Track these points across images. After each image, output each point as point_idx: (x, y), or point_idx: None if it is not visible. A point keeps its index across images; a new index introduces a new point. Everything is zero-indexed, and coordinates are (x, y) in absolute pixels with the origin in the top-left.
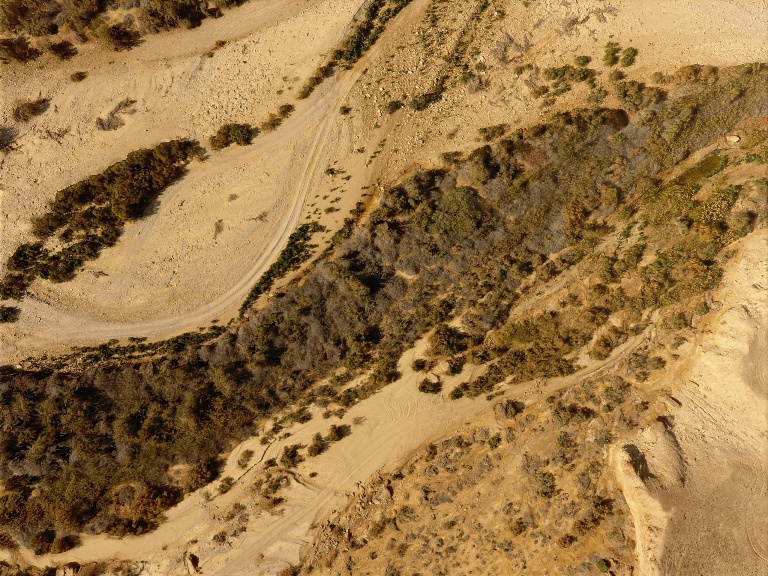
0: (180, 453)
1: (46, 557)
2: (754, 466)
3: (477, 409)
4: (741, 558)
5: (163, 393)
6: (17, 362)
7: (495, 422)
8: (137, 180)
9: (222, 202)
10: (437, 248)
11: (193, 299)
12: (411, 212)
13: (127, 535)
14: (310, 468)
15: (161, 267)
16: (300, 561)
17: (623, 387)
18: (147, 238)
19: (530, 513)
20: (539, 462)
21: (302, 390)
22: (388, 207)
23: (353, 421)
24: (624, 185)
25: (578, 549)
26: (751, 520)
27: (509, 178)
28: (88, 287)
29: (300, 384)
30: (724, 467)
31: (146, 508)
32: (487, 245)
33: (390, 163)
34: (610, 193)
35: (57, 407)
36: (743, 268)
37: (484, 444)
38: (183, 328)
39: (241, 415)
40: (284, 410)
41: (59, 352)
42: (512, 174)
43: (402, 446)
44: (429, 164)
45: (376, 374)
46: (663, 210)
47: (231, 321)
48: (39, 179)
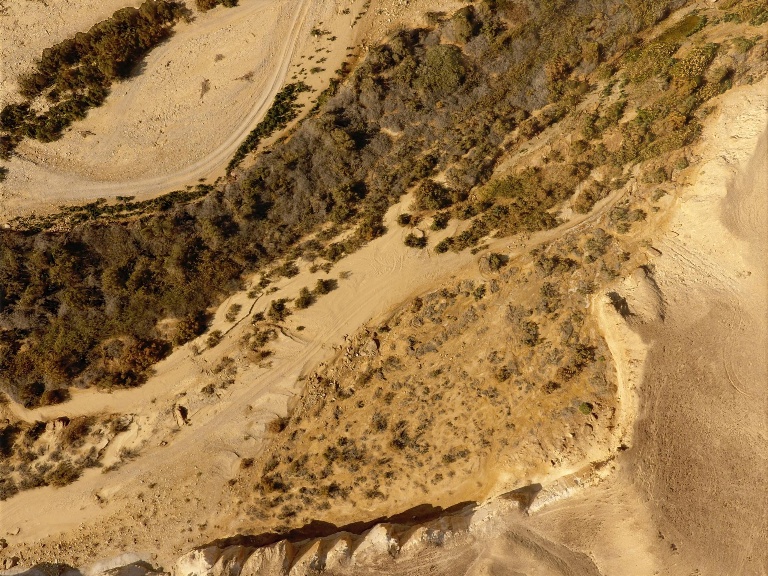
0: (168, 307)
1: (36, 412)
2: (732, 304)
3: (462, 263)
4: (719, 391)
5: (151, 248)
6: (5, 222)
7: (479, 275)
8: (123, 37)
9: (208, 62)
10: (421, 105)
11: (180, 158)
12: (395, 67)
13: (116, 389)
14: (297, 322)
15: (148, 126)
16: (288, 413)
17: (605, 238)
18: (134, 98)
19: (514, 361)
20: (523, 312)
21: (289, 245)
22: (373, 64)
23: (340, 275)
24: (605, 41)
25: (561, 395)
26: (729, 354)
27: (492, 34)
28: (75, 147)
29: (287, 237)
30: (703, 305)
31: (135, 358)
32: (471, 101)
33: (375, 24)
34: (591, 46)
35: (45, 262)
36: (722, 123)
37: (469, 296)
38: (170, 187)
39: (228, 267)
40: (271, 265)
41: (47, 212)
42: (495, 29)
43: (388, 300)
44: (413, 24)
45: (362, 226)
46: (643, 67)
47: (218, 179)
48: (26, 41)
